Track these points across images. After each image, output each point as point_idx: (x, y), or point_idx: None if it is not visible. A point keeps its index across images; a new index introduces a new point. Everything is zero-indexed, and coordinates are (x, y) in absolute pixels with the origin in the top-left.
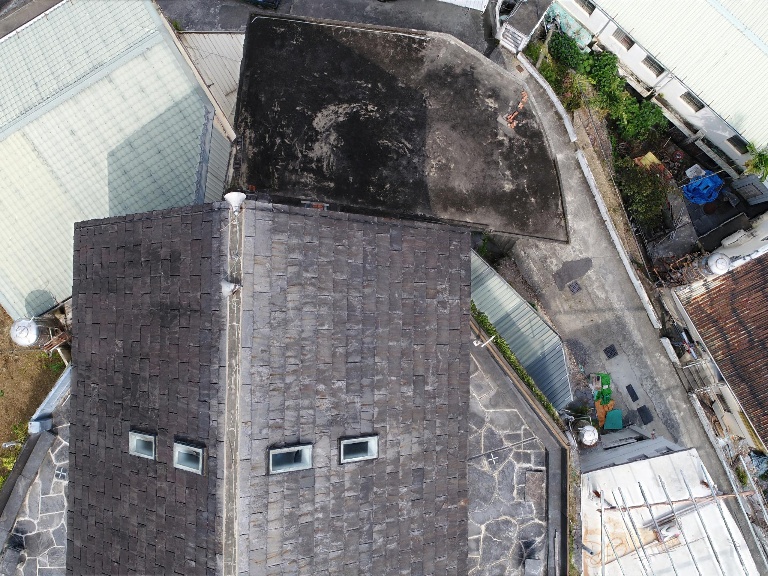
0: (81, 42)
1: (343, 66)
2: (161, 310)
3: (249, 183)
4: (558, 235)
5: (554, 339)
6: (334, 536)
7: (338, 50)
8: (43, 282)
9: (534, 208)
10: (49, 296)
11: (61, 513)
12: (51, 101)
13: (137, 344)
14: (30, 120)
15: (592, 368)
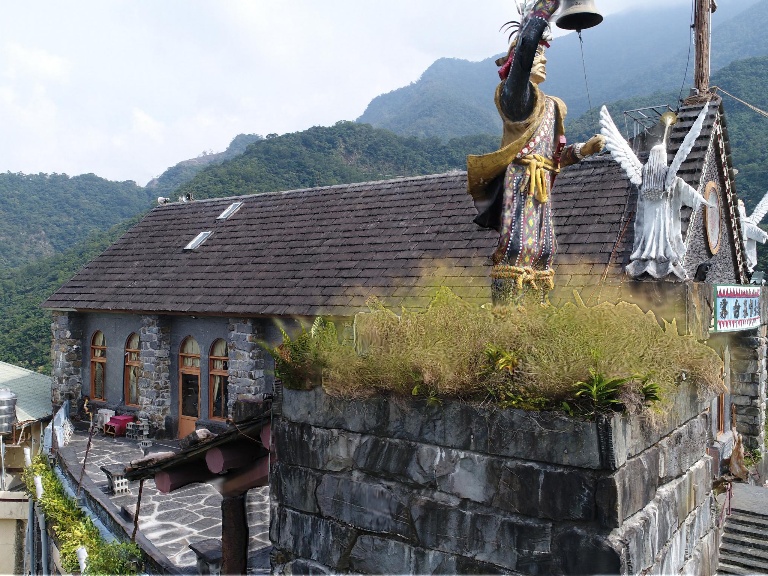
0: None
1: None
2: None
3: None
4: None
5: None
6: None
7: None
8: None
9: None
10: None
11: None
12: None
13: None
14: None
15: None
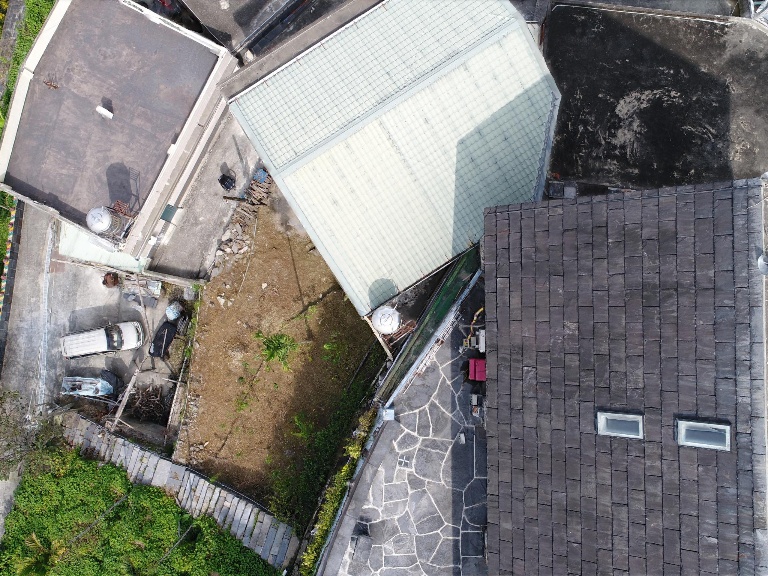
0: (429, 31)
1: (645, 53)
2: (645, 290)
3: (553, 171)
4: None
5: None
6: None
7: (639, 37)
8: (387, 271)
9: None
10: (391, 285)
11: (405, 501)
12: (409, 90)
13: (603, 325)
14: (388, 109)
15: None
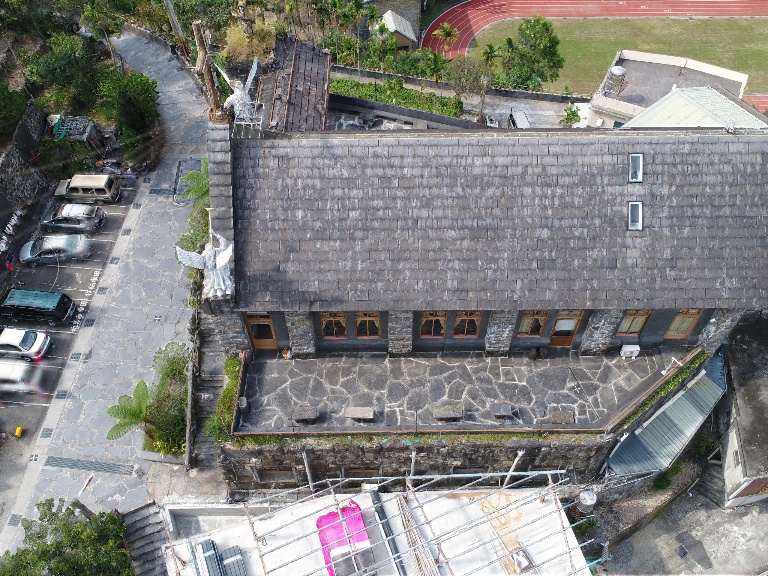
0: None
1: None
2: None
3: None
4: (750, 469)
5: (665, 462)
6: (586, 200)
7: None
8: None
9: (766, 449)
10: None
11: None
12: None
13: None
14: None
15: (611, 569)
